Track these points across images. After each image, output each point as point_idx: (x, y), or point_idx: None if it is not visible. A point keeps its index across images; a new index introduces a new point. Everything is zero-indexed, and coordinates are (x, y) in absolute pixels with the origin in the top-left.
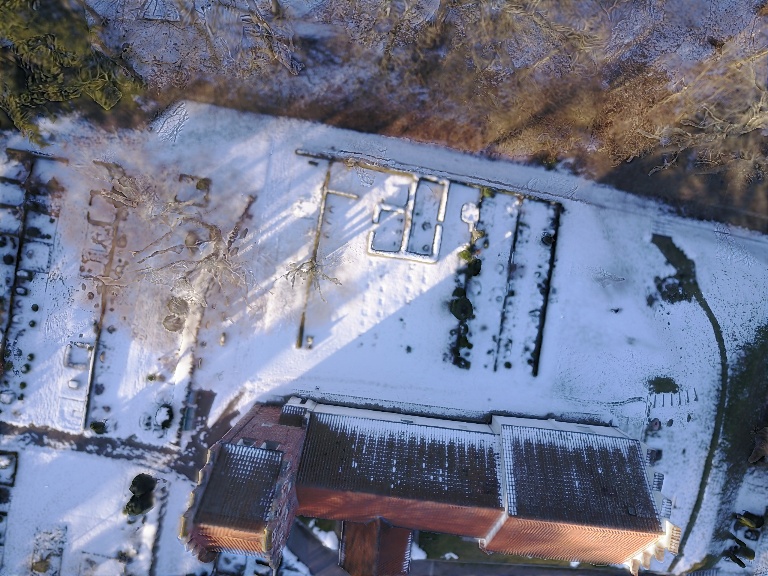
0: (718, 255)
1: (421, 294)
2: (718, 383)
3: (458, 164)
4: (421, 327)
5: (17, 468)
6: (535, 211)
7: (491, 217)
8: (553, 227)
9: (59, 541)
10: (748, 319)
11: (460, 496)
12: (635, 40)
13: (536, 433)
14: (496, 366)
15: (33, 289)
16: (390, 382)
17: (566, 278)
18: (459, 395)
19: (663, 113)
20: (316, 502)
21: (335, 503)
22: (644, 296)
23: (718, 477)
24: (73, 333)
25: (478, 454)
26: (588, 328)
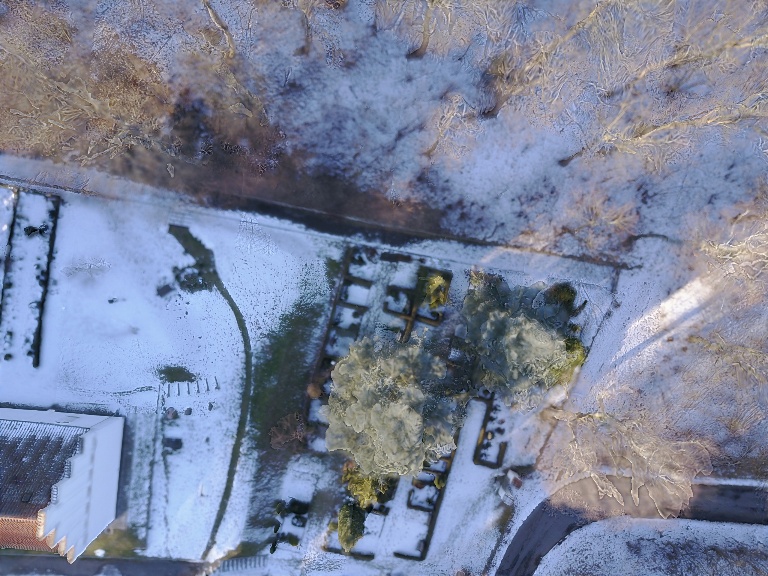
0: (237, 244)
1: None
2: (242, 371)
3: None
4: None
5: None
6: (35, 204)
7: None
8: (53, 219)
9: None
10: (271, 307)
11: None
12: (123, 33)
13: None
14: None
15: None
16: None
17: None
18: None
19: (158, 105)
20: None
21: None
22: (155, 286)
23: (248, 464)
24: None
25: None
26: (91, 319)
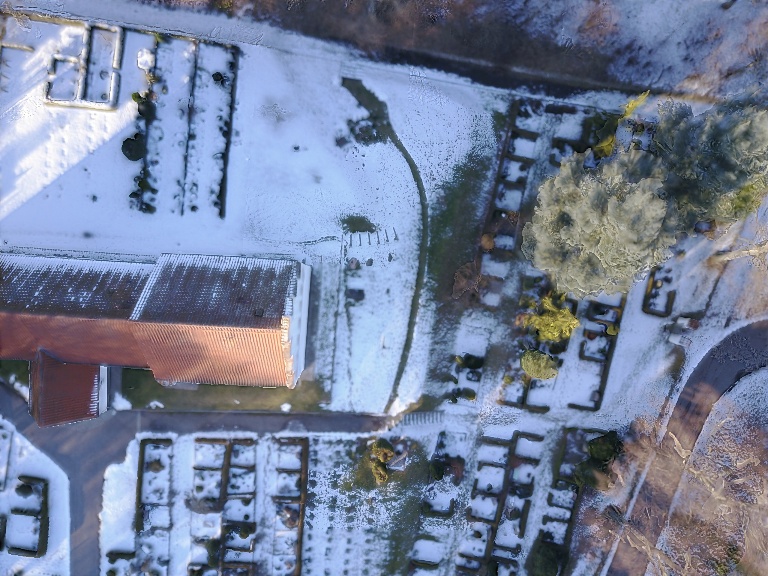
0: (410, 96)
1: (104, 143)
2: (419, 222)
3: (138, 15)
4: (106, 176)
5: None
6: (214, 56)
7: (169, 63)
8: (233, 71)
9: None
10: (445, 158)
11: (94, 311)
12: None
13: (194, 258)
14: (183, 211)
15: None
16: (78, 232)
17: (249, 121)
18: (148, 241)
19: None
20: None
21: None
22: (333, 137)
23: (427, 316)
24: None
25: (132, 280)
26: (275, 169)
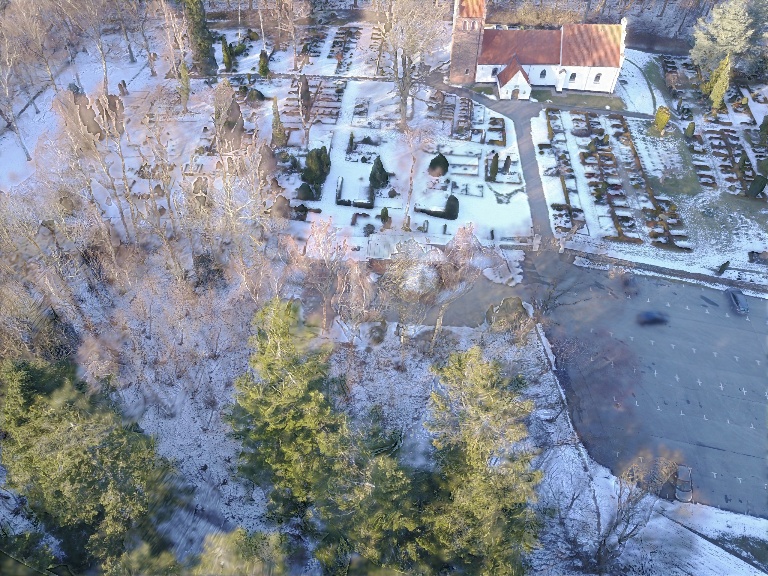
0: None
1: None
2: (640, 71)
3: None
4: None
5: (347, 85)
6: None
7: None
8: None
9: (367, 101)
10: (641, 60)
11: None
12: None
13: None
14: None
15: None
16: None
17: None
18: None
19: None
20: (489, 45)
21: (496, 43)
22: None
23: (657, 92)
24: None
25: None
26: None
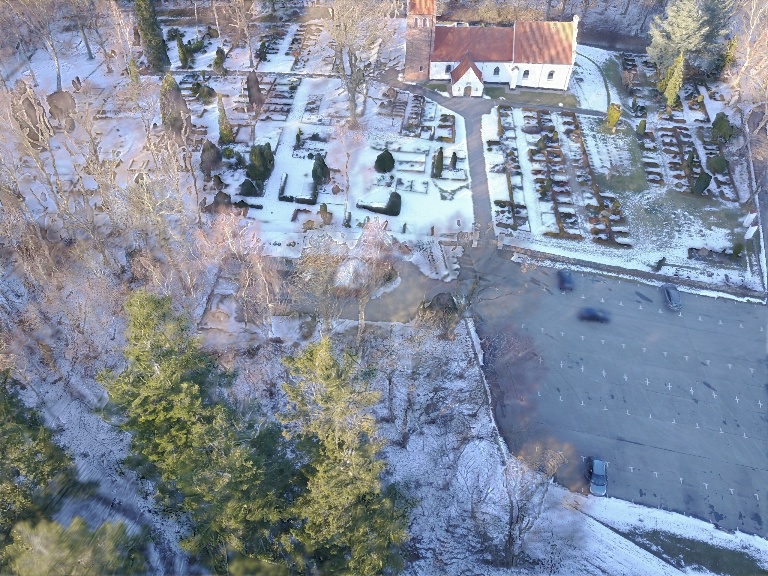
0: None
1: None
2: (598, 69)
3: None
4: None
5: (301, 82)
6: None
7: None
8: None
9: (320, 98)
10: None
11: None
12: None
13: None
14: None
15: (308, 49)
16: None
17: None
18: None
19: None
20: (441, 43)
21: (449, 40)
22: None
23: None
24: (326, 55)
25: None
26: None
